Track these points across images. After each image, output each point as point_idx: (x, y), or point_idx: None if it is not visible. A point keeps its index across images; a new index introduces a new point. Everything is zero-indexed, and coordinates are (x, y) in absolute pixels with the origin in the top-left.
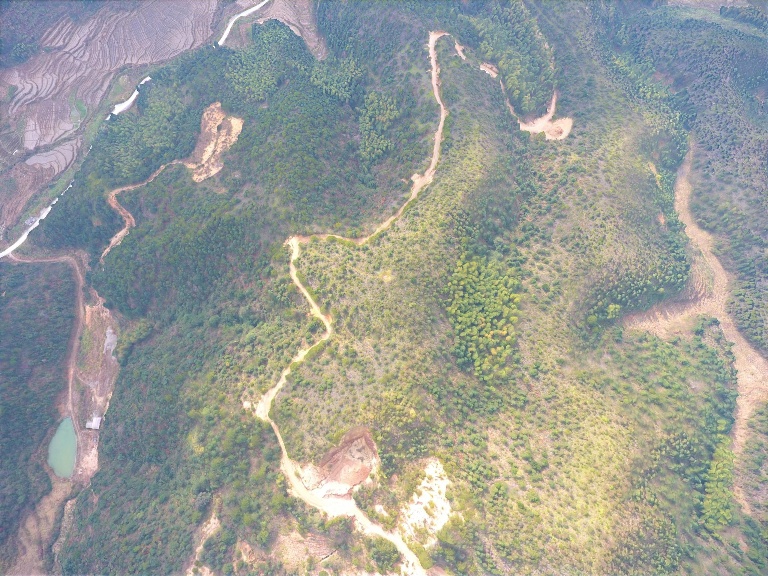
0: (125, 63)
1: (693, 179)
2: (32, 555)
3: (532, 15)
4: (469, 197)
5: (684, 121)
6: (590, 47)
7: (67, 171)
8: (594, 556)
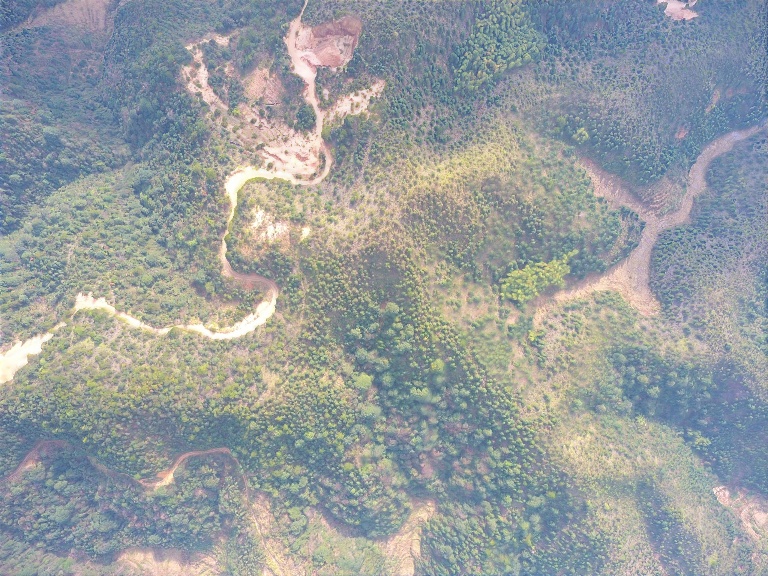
0: None
1: (739, 144)
2: None
3: None
4: None
5: None
6: None
7: None
8: (421, 183)
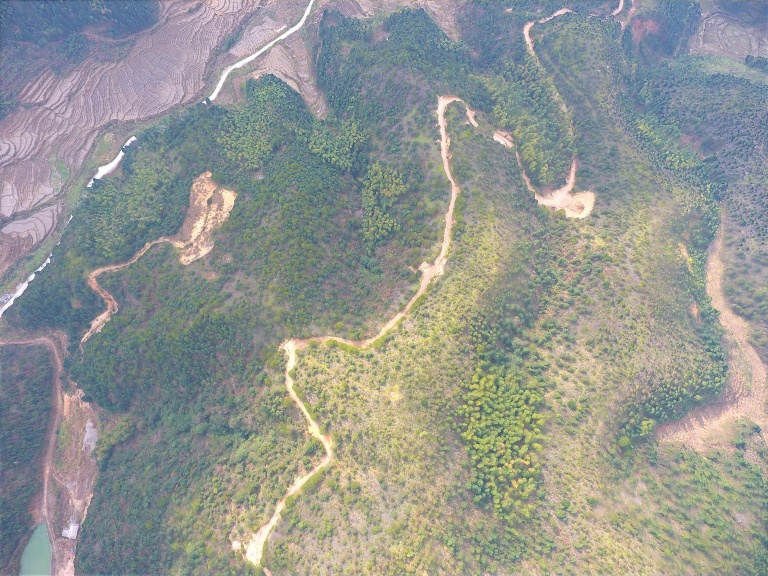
0: (110, 119)
1: (725, 257)
2: None
3: (548, 73)
4: (485, 296)
5: (714, 191)
6: (612, 111)
7: (46, 240)
8: None
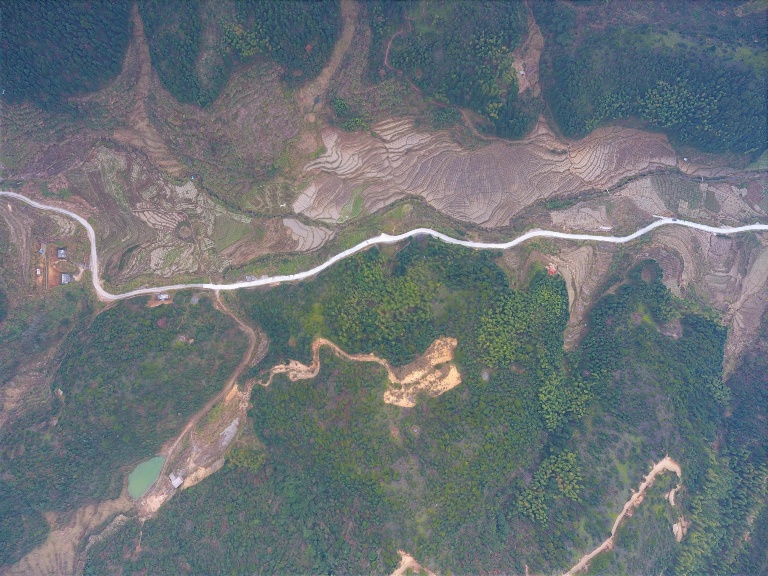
0: (420, 194)
1: None
2: (76, 532)
3: (765, 495)
4: None
5: None
6: None
7: (306, 254)
8: None
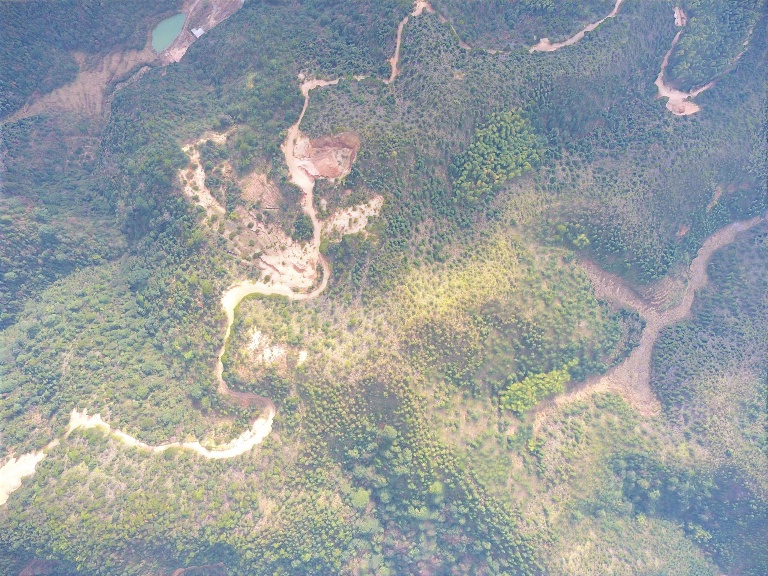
0: None
1: (740, 236)
2: (104, 77)
3: (761, 11)
4: (565, 79)
5: None
6: None
7: None
8: (419, 313)
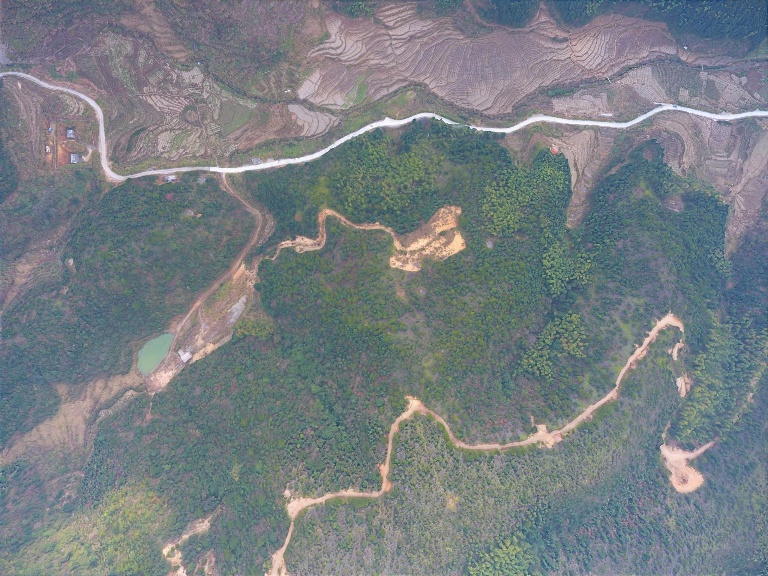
0: (424, 81)
1: None
2: (87, 405)
3: None
4: (563, 495)
5: None
6: None
7: (311, 139)
8: None
